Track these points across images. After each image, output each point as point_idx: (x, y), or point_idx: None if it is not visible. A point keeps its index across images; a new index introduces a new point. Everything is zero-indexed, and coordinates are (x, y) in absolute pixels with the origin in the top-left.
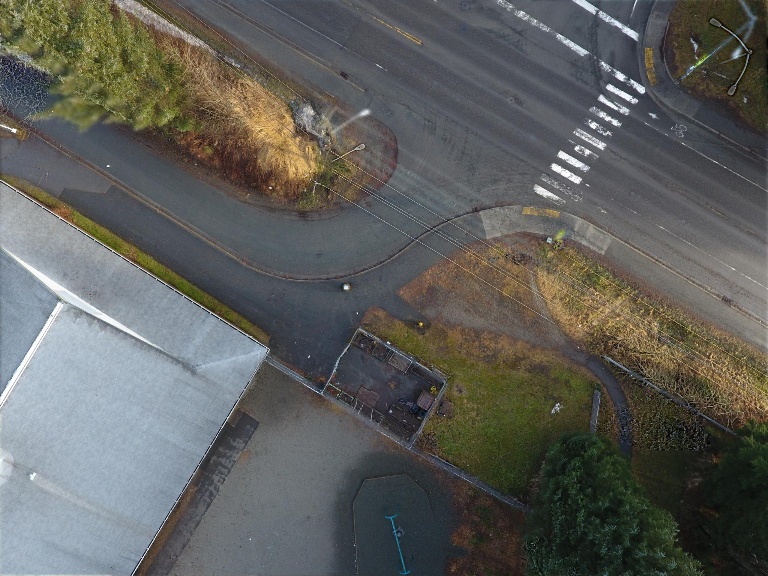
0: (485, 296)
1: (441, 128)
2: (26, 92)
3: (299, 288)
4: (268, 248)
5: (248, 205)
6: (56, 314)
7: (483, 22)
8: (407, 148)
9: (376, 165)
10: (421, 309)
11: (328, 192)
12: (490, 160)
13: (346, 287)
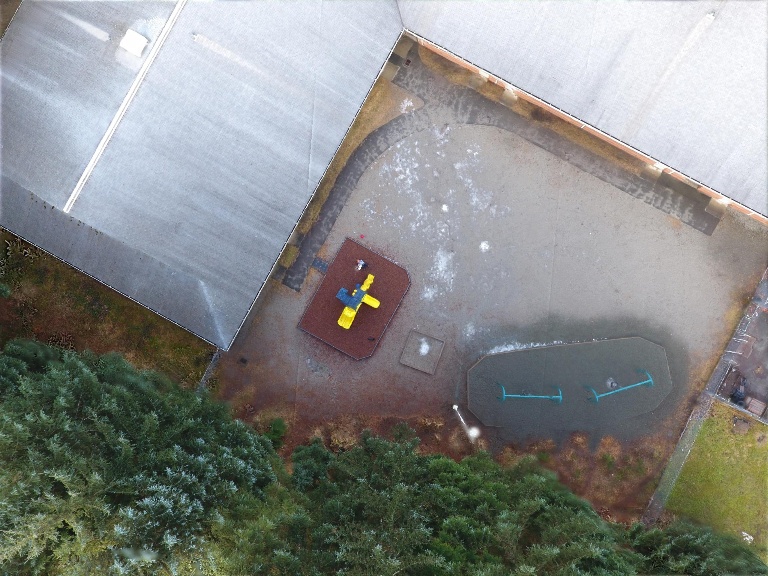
0: None
1: None
2: None
3: None
4: None
5: None
6: None
7: None
8: None
9: None
10: None
11: None
12: None
13: None
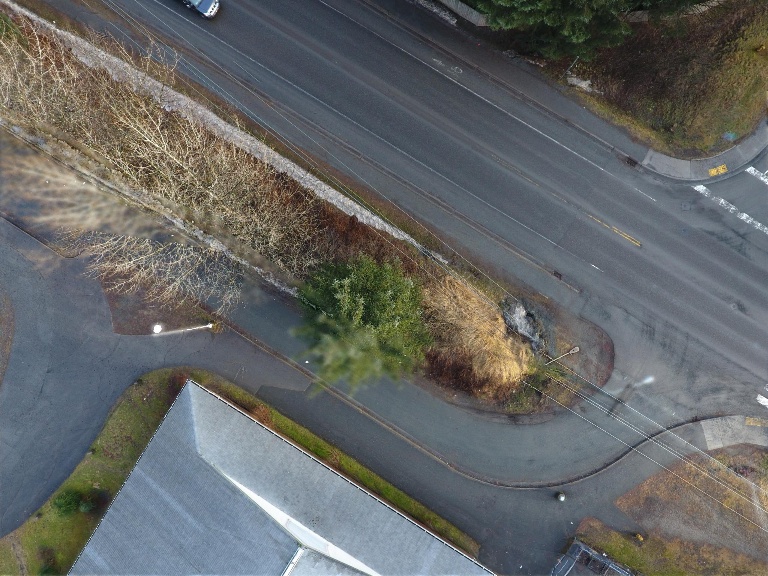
0: (705, 508)
1: (660, 333)
2: (219, 282)
3: (511, 496)
4: (477, 452)
5: (455, 406)
6: (297, 561)
7: (704, 224)
8: (624, 353)
9: (591, 369)
10: (638, 520)
11: (541, 396)
12: (711, 368)
13: (562, 498)
